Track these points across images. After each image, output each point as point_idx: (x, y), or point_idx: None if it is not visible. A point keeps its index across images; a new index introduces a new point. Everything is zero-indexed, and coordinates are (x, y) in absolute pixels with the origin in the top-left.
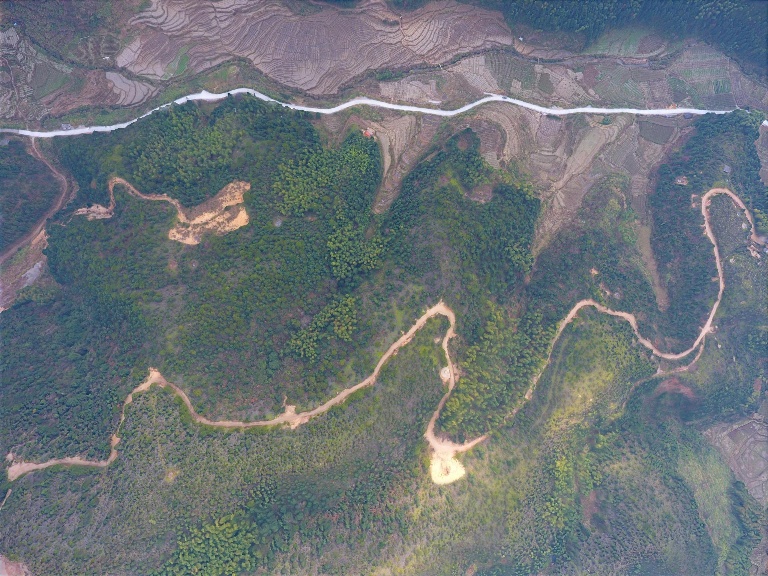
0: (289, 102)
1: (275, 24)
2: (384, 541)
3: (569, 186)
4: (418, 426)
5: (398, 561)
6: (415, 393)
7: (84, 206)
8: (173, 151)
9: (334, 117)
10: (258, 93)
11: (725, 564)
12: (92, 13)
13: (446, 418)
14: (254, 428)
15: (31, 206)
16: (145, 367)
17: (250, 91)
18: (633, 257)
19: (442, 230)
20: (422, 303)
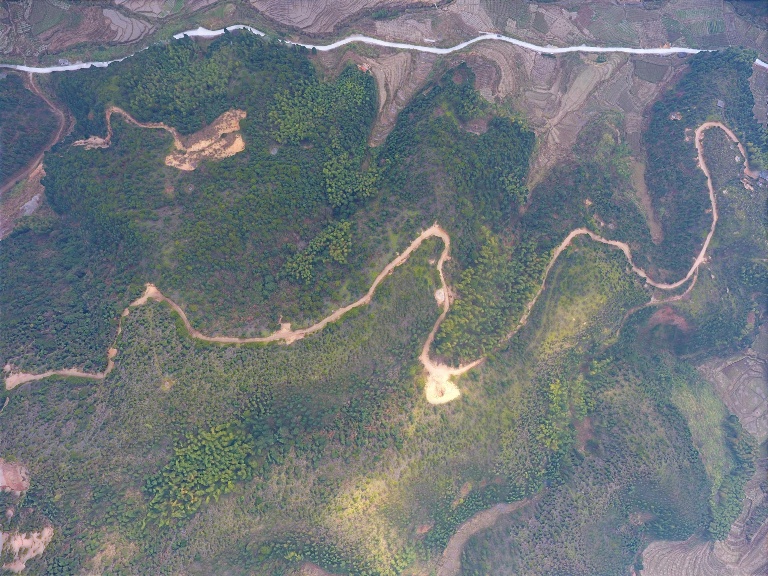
0: (285, 39)
1: None
2: (379, 455)
3: (564, 123)
4: (413, 347)
5: (393, 474)
6: (410, 312)
7: (81, 138)
8: (170, 83)
9: (330, 54)
10: (254, 30)
11: (719, 493)
12: None
13: (441, 340)
14: (250, 343)
15: (29, 138)
16: (142, 283)
17: (246, 28)
18: (627, 191)
19: (437, 157)
20: (417, 226)
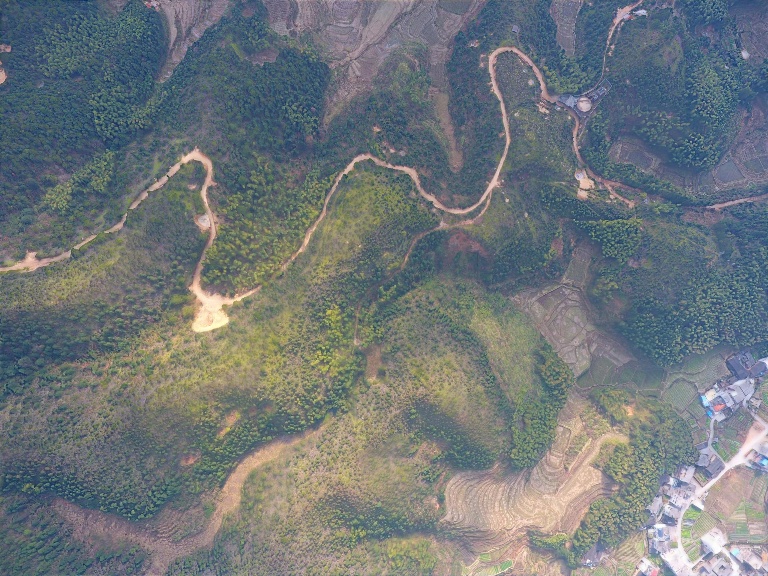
0: None
1: None
2: (127, 382)
3: (365, 56)
4: (175, 274)
5: (138, 400)
6: (165, 237)
7: None
8: None
9: None
10: None
11: (523, 420)
12: None
13: (208, 268)
14: None
15: None
16: None
17: None
18: (427, 121)
19: (209, 85)
20: (178, 152)
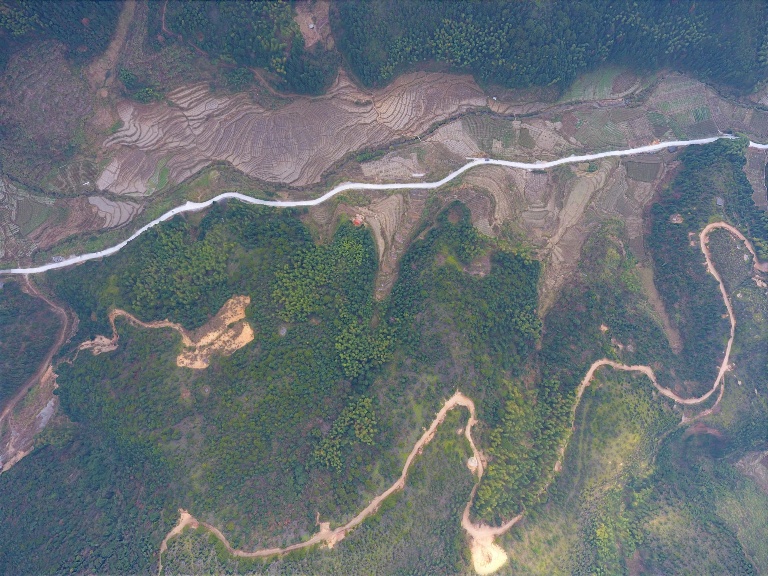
0: (274, 199)
1: (249, 122)
2: None
3: (565, 239)
4: (454, 520)
5: None
6: (446, 490)
7: (87, 339)
8: (167, 271)
9: (321, 208)
10: (242, 195)
11: None
12: (66, 143)
13: (480, 506)
14: (292, 554)
15: (35, 346)
16: (175, 509)
17: (234, 195)
18: (640, 303)
19: (447, 314)
20: (439, 395)
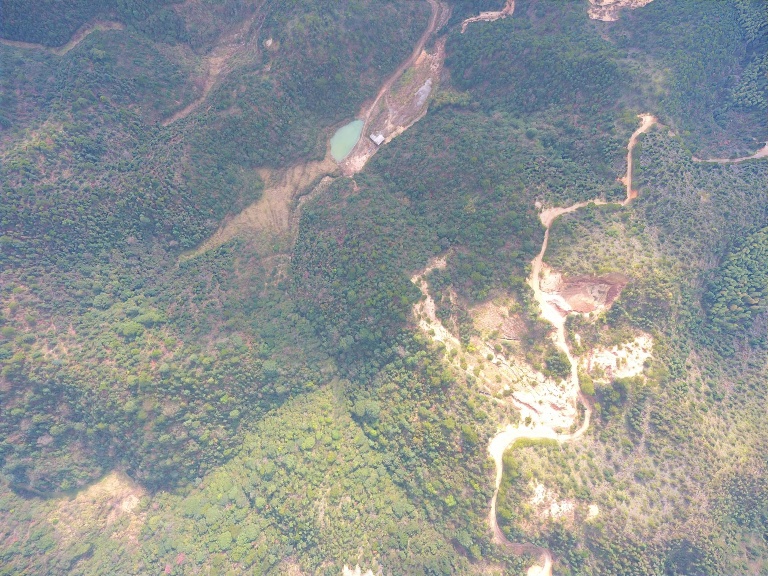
0: None
1: None
2: None
3: None
4: None
5: None
6: None
7: (471, 16)
8: None
9: None
10: None
11: None
12: None
13: None
14: (747, 159)
15: (417, 24)
16: (633, 115)
17: None
18: None
19: None
20: None
